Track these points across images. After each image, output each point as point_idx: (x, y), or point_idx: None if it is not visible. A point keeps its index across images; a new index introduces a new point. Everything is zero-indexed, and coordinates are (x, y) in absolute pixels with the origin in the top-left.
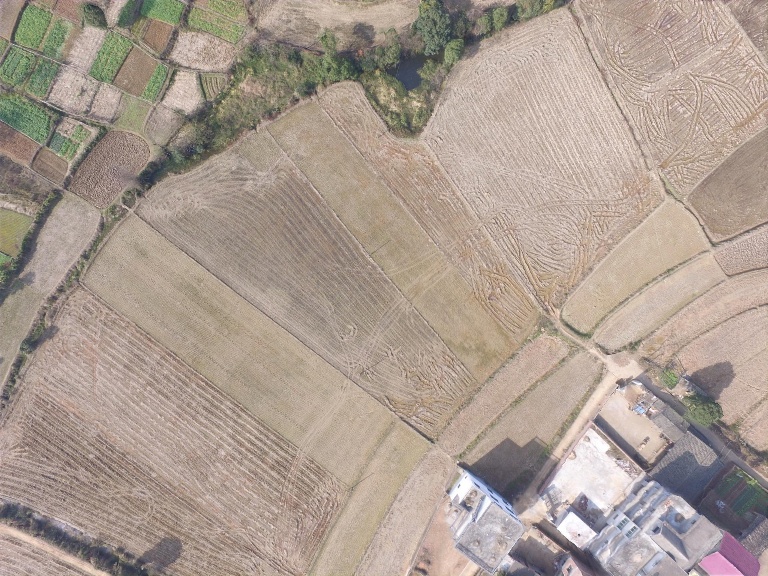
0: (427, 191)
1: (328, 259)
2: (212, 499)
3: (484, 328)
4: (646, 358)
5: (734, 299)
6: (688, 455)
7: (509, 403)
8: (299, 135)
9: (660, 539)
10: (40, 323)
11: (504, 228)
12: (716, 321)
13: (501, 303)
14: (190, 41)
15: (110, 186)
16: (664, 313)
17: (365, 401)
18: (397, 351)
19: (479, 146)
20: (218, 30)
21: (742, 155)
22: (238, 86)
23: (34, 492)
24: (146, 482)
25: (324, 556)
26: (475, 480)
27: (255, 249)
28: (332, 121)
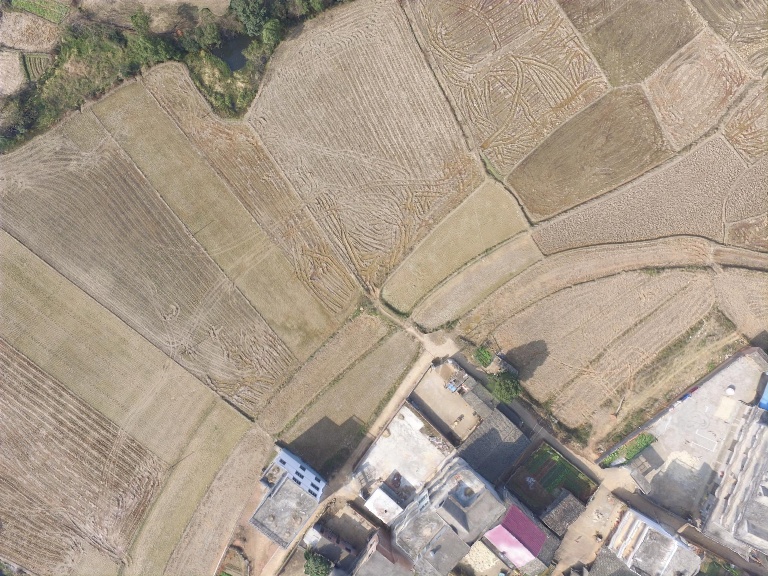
0: (251, 171)
1: (151, 239)
2: (33, 478)
3: (306, 308)
4: (463, 337)
5: (550, 278)
6: (493, 432)
7: (328, 382)
8: (123, 115)
9: (443, 512)
10: None
11: (326, 208)
12: (532, 300)
13: (323, 283)
14: (14, 21)
15: None
16: (482, 292)
17: (187, 380)
18: (219, 331)
19: (302, 127)
20: (41, 10)
21: (561, 136)
22: (63, 66)
23: None
24: None
25: (144, 534)
26: (287, 458)
27: (78, 229)
28: (156, 102)
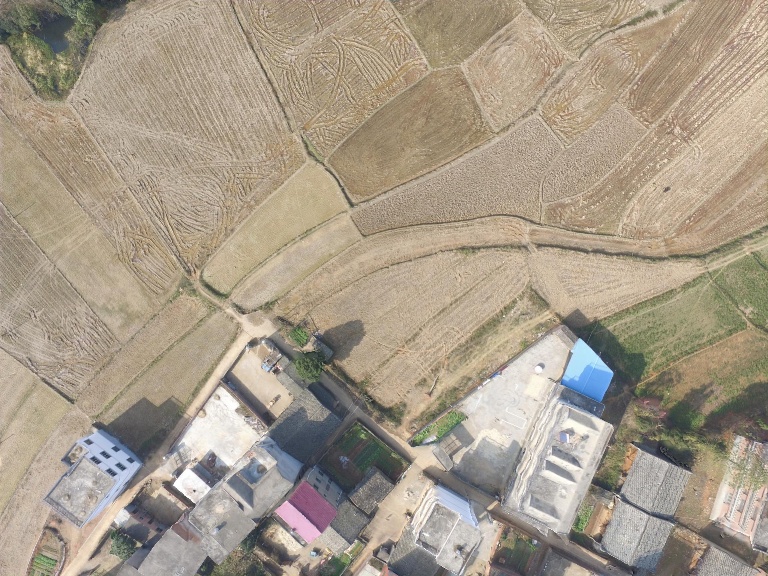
0: (73, 153)
1: None
2: None
3: (127, 289)
4: (281, 317)
5: (368, 259)
6: (302, 411)
7: (148, 363)
8: None
9: (228, 489)
10: None
11: (148, 190)
12: (350, 280)
13: (145, 264)
14: None
15: None
16: (301, 273)
17: (7, 363)
18: (40, 313)
19: (125, 109)
20: None
21: (382, 117)
22: None
23: None
24: None
25: None
26: (100, 438)
27: None
28: None
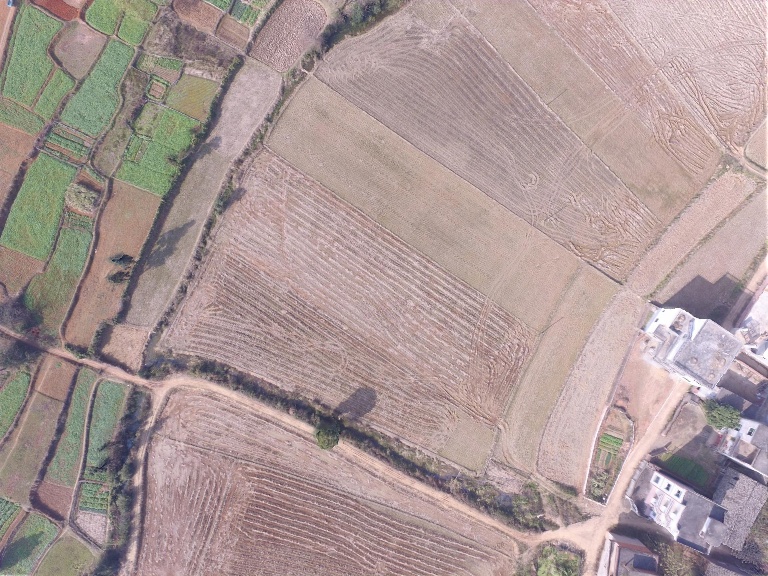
0: (601, 39)
1: (506, 111)
2: (404, 349)
3: (666, 170)
4: None
5: None
6: None
7: (697, 242)
8: None
9: None
10: (228, 186)
11: (681, 71)
12: None
13: (682, 145)
14: None
15: (290, 50)
16: None
17: (550, 247)
18: (580, 197)
19: None
20: None
21: None
22: None
23: (230, 349)
24: (338, 335)
25: (518, 400)
26: None
27: (433, 105)
28: None
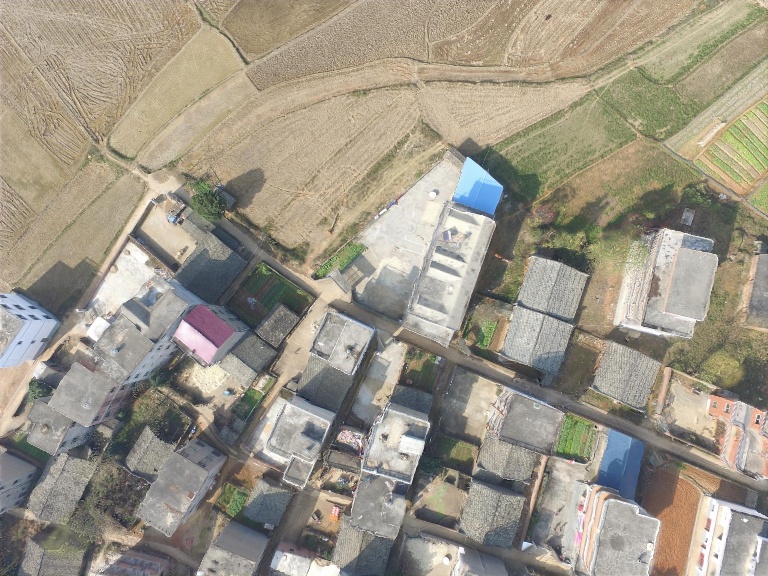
0: None
1: None
2: None
3: (40, 162)
4: (185, 173)
5: (265, 111)
6: (204, 252)
7: None
8: None
9: (125, 312)
10: None
11: (55, 68)
12: (249, 133)
13: (55, 138)
14: None
15: None
16: (202, 131)
17: None
18: None
19: None
20: None
21: None
22: None
23: None
24: None
25: None
26: (17, 298)
27: None
28: None
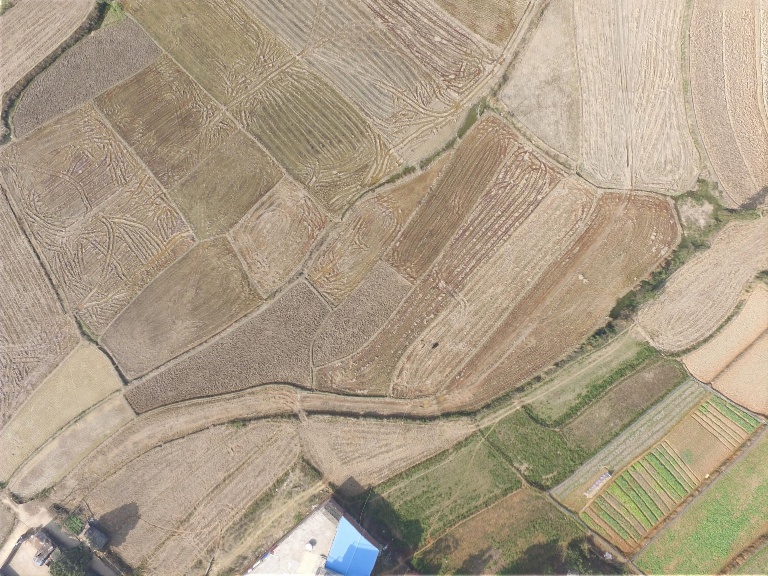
0: None
1: None
2: None
3: None
4: (57, 504)
5: (142, 438)
6: None
7: None
8: None
9: None
10: None
11: None
12: (125, 461)
13: None
14: None
15: None
16: (76, 457)
17: None
18: None
19: None
20: None
21: (152, 292)
22: None
23: None
24: None
25: None
26: None
27: None
28: None
